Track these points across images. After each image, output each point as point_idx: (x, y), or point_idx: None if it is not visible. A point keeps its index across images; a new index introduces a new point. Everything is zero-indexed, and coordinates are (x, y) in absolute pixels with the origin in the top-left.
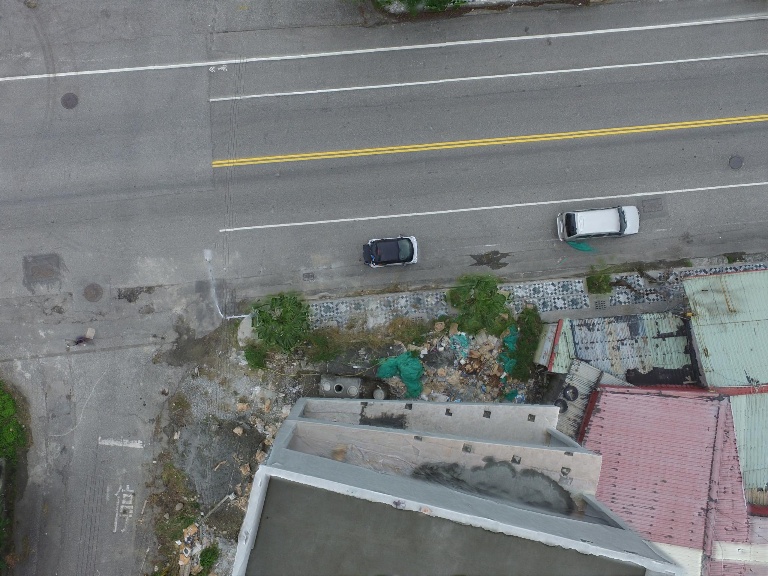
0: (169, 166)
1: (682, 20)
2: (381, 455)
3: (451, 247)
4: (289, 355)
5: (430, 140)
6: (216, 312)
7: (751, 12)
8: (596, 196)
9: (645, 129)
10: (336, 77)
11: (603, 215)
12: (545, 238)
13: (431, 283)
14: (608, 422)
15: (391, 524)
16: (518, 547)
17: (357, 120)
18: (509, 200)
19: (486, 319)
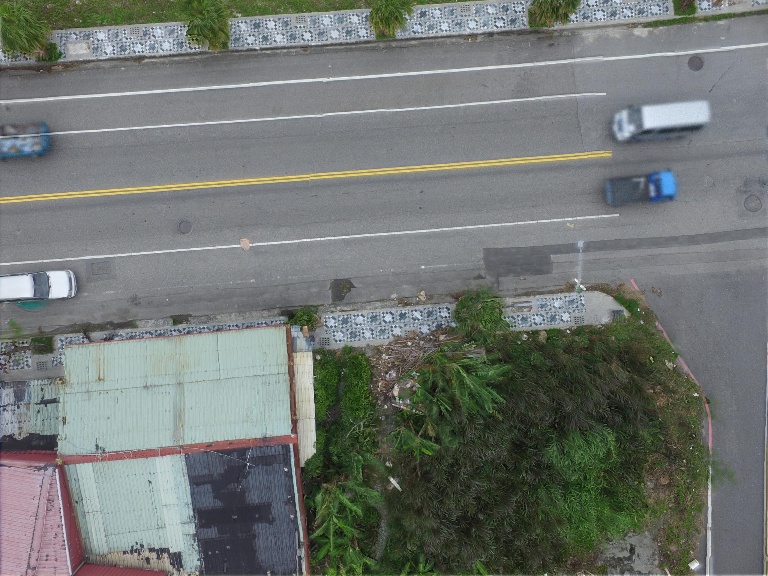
0: None
1: (143, 88)
2: None
3: None
4: None
5: None
6: None
7: (210, 81)
8: (45, 259)
9: (96, 194)
10: None
11: (11, 281)
12: None
13: None
14: None
15: None
16: None
17: None
18: None
19: None
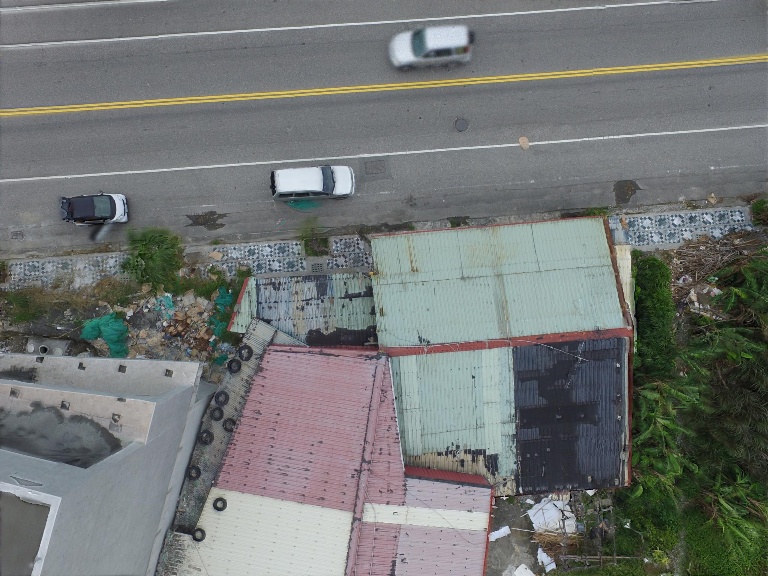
0: None
1: None
2: None
3: (166, 207)
4: None
5: (147, 96)
6: None
7: None
8: (317, 157)
9: (369, 89)
10: (53, 30)
11: (302, 173)
12: (264, 199)
13: None
14: (269, 381)
15: None
16: None
17: (72, 75)
18: (227, 159)
19: (152, 274)
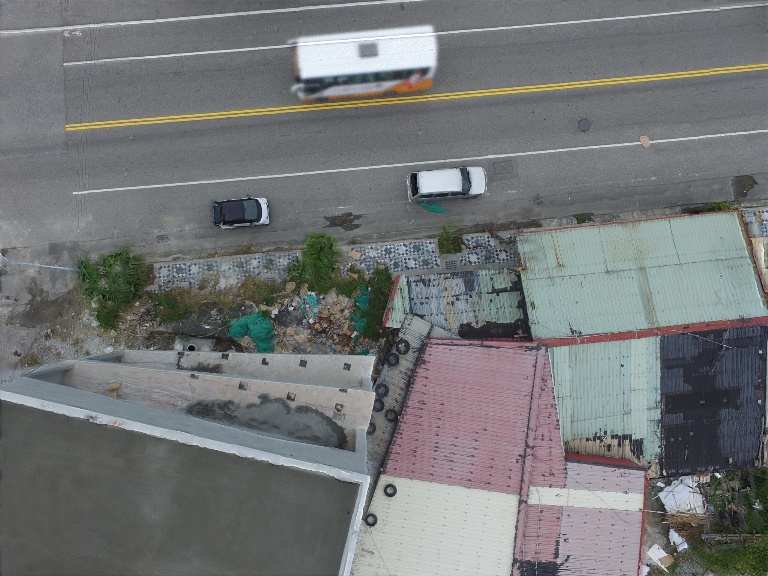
0: (22, 129)
1: None
2: (145, 389)
3: (304, 209)
4: (142, 316)
5: (283, 103)
6: (69, 274)
7: None
8: (448, 158)
9: (496, 92)
10: (191, 41)
11: (444, 174)
12: (398, 200)
13: (284, 244)
14: (432, 373)
15: (111, 444)
16: (235, 465)
17: (211, 84)
18: (361, 162)
19: (316, 274)
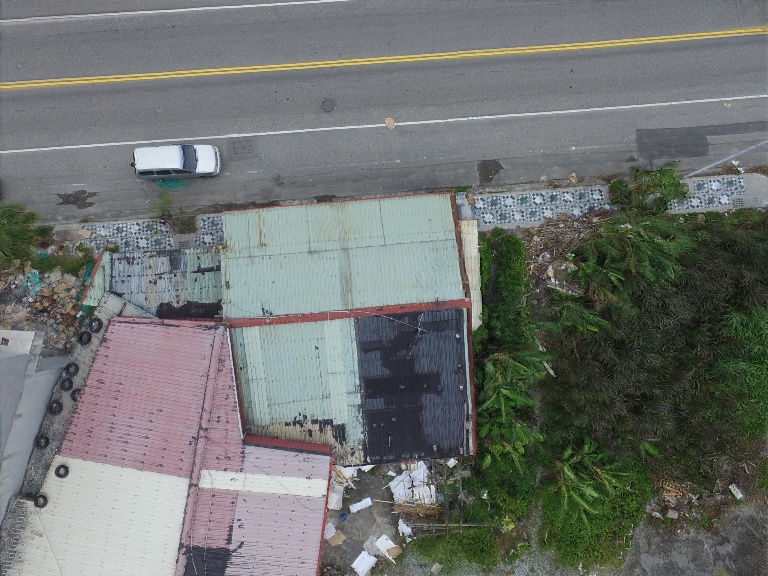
0: None
1: None
2: None
3: (37, 186)
4: None
5: (18, 78)
6: None
7: None
8: (186, 137)
9: (238, 71)
10: None
11: (162, 151)
12: (134, 178)
13: None
14: (113, 351)
15: None
16: None
17: None
18: (97, 139)
19: (1, 248)
